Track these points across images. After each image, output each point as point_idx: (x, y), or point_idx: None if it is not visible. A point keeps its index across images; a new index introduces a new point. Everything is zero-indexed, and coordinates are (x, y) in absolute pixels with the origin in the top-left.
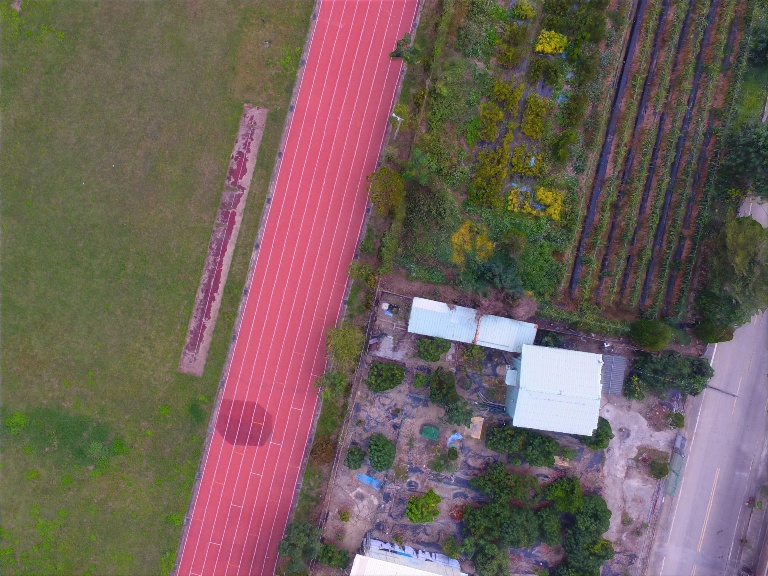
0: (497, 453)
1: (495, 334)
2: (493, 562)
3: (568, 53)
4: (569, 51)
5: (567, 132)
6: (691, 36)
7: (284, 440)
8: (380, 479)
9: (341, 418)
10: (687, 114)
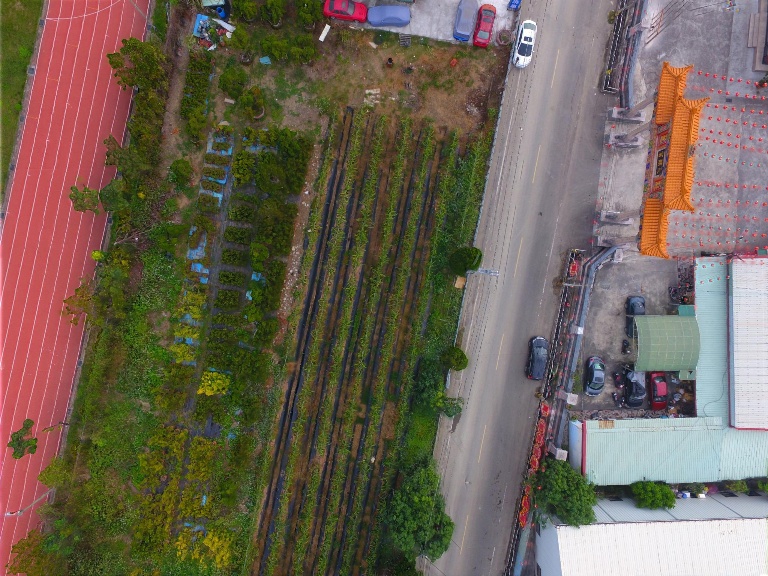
0: None
1: None
2: None
3: None
4: None
5: (225, 484)
6: None
7: None
8: None
9: None
10: (361, 445)
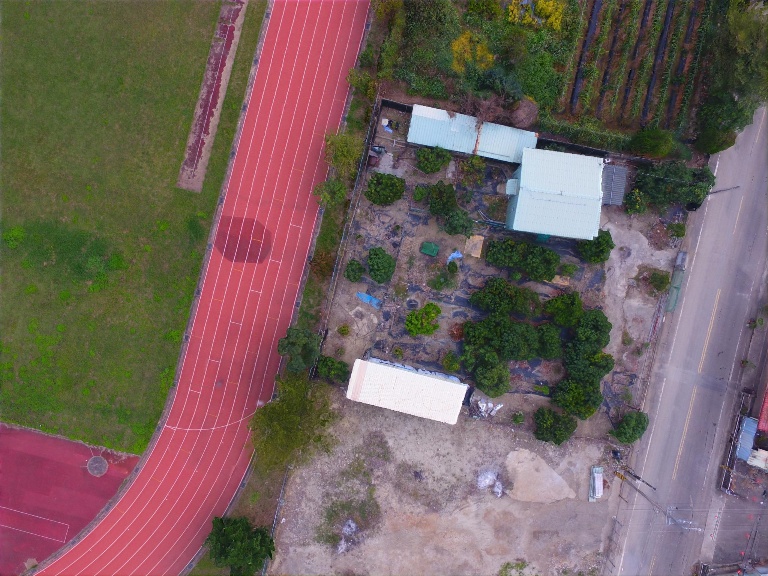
0: (497, 272)
1: (495, 143)
2: (493, 369)
3: None
4: None
5: None
6: None
7: (283, 257)
8: (380, 298)
9: (340, 233)
10: None
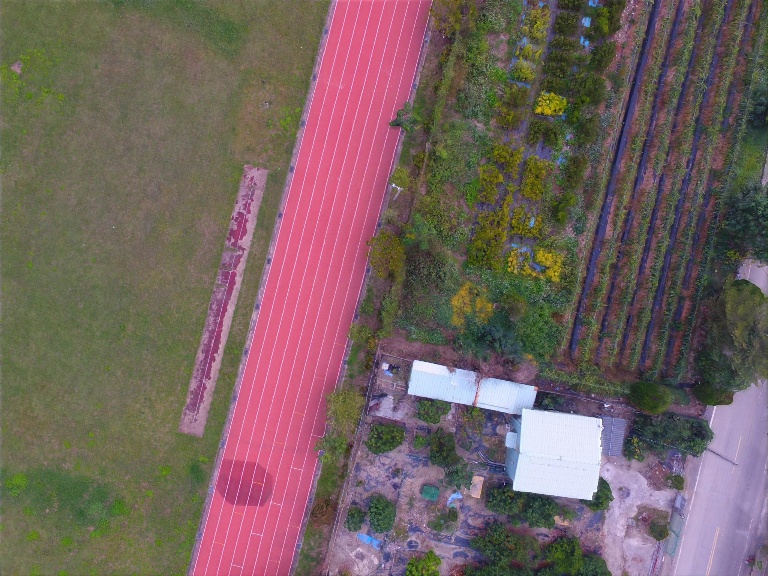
0: None
1: (495, 396)
2: None
3: (568, 115)
4: (569, 113)
5: (567, 195)
6: (690, 98)
7: (284, 500)
8: (380, 539)
9: (341, 479)
10: (686, 175)
